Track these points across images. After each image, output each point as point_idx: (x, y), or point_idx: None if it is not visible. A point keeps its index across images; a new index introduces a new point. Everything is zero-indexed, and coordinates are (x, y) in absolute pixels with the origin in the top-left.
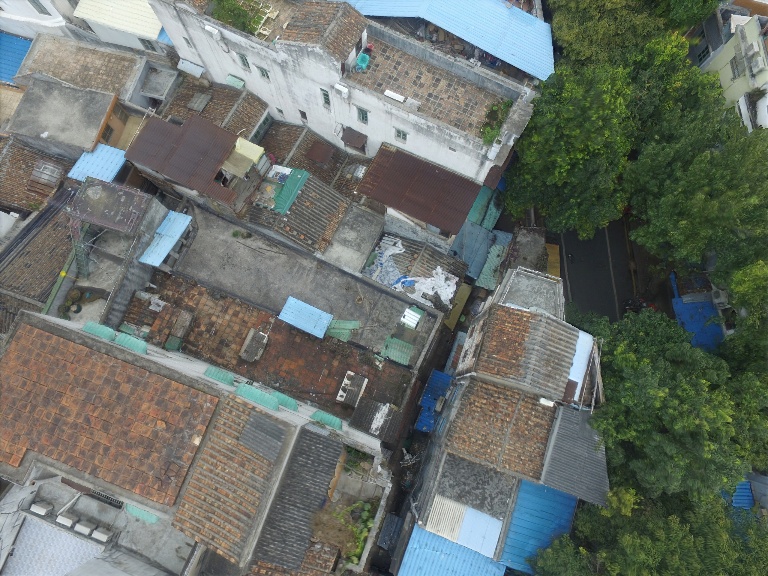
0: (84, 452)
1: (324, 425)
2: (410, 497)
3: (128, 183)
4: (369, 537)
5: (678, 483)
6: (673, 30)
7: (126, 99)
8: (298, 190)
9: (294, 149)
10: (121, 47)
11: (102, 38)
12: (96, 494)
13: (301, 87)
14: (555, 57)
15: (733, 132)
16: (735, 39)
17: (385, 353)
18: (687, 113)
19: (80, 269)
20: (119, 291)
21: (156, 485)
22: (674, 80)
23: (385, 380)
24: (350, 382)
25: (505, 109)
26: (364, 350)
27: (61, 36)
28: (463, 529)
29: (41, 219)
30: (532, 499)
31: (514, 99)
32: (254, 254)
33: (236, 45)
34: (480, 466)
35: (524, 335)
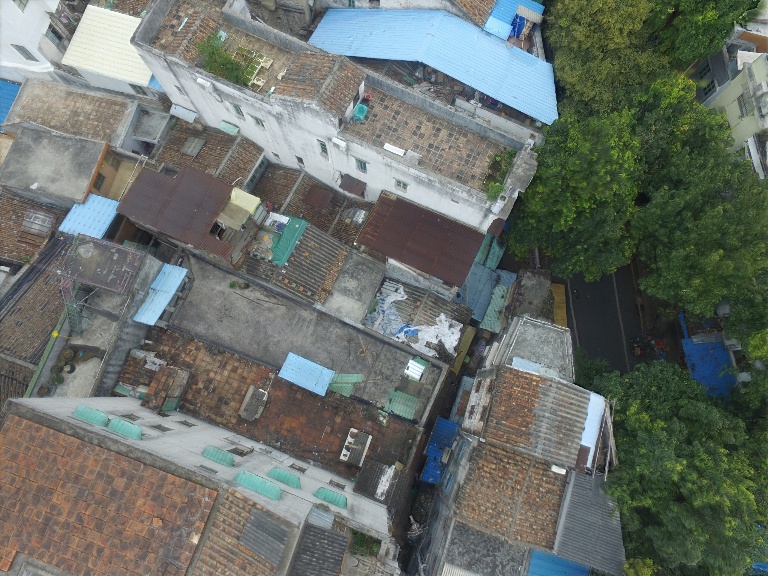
0: (77, 554)
1: (328, 507)
2: (417, 554)
3: (121, 233)
4: None
5: None
6: (677, 64)
7: (118, 145)
8: (296, 240)
9: (291, 194)
10: (111, 91)
11: (92, 83)
12: None
13: (297, 137)
14: (557, 96)
15: (746, 185)
16: (742, 77)
17: (389, 407)
18: (695, 156)
19: (73, 327)
20: (113, 353)
21: None
22: (681, 123)
23: (390, 436)
24: (354, 440)
25: (508, 159)
26: (367, 405)
27: (50, 81)
28: None
29: (32, 272)
30: (545, 565)
31: (517, 149)
32: (252, 306)
33: (229, 96)
34: None
35: (534, 401)
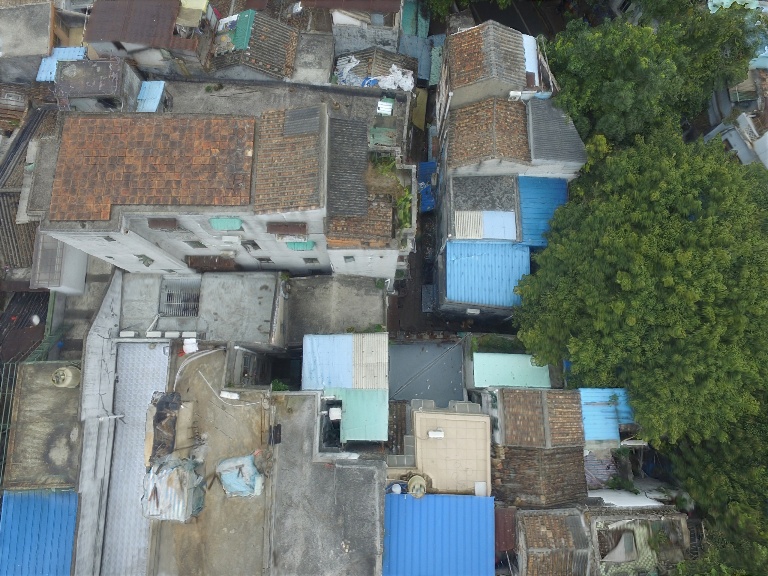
0: (160, 191)
1: None
2: (436, 259)
3: None
4: (412, 206)
5: (632, 101)
6: None
7: (62, 9)
8: (250, 27)
9: (232, 6)
10: None
11: None
12: (171, 315)
13: None
14: None
15: None
16: None
17: (374, 141)
18: None
19: None
20: None
21: (230, 194)
22: None
23: None
24: None
25: None
26: None
27: None
28: (485, 227)
29: (24, 134)
30: (531, 191)
31: None
32: (231, 100)
33: None
34: (482, 179)
35: (480, 45)
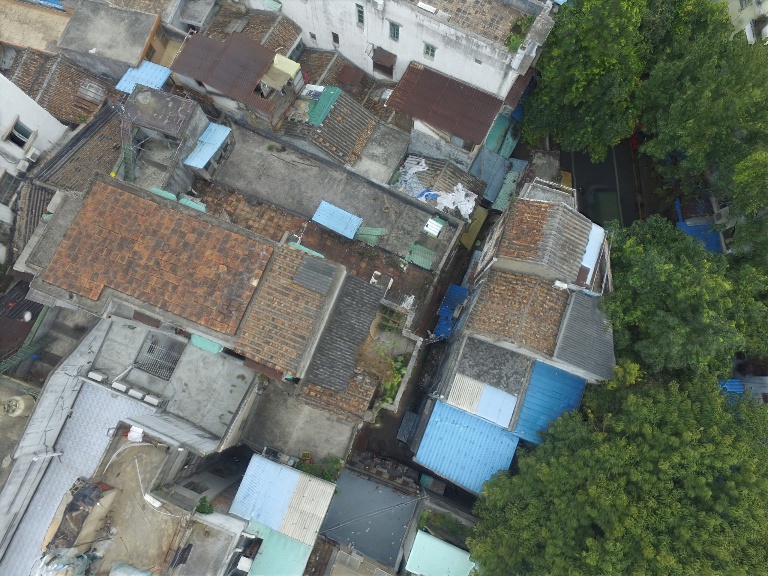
0: (155, 289)
1: None
2: (429, 393)
3: None
4: (402, 382)
5: (679, 348)
6: None
7: (168, 22)
8: (331, 105)
9: (326, 72)
10: None
11: None
12: (145, 369)
13: (337, 4)
14: None
15: (739, 41)
16: None
17: (409, 258)
18: (697, 37)
19: (127, 173)
20: (166, 188)
21: (219, 318)
22: (686, 4)
23: (409, 281)
24: (377, 281)
25: (528, 24)
26: (390, 254)
27: None
28: (481, 403)
29: (88, 131)
30: (544, 380)
31: (537, 15)
32: (288, 166)
33: None
34: (497, 349)
35: (542, 223)
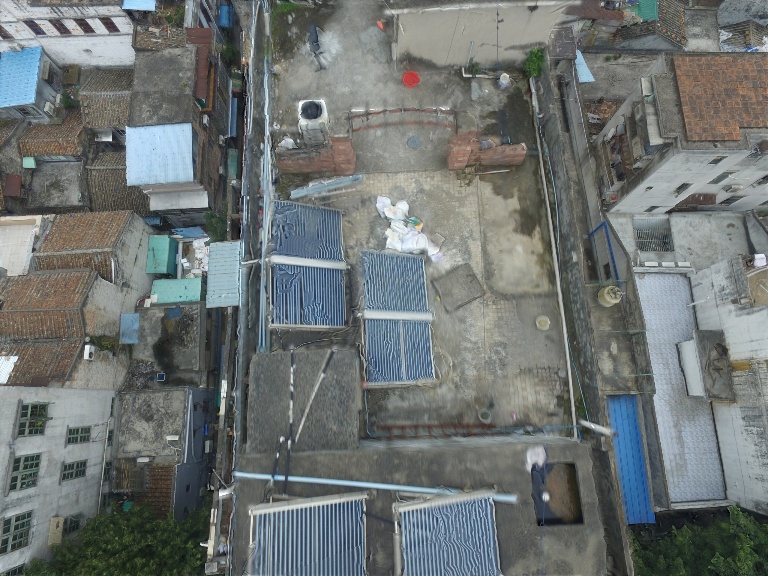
0: None
1: None
2: None
3: None
4: None
5: None
6: None
7: None
8: (656, 2)
9: None
10: None
11: None
12: None
13: None
14: None
15: None
16: None
17: None
18: None
19: None
20: None
21: None
22: None
23: None
24: None
25: None
26: None
27: None
28: None
29: None
30: None
31: None
32: (631, 68)
33: None
34: None
35: None
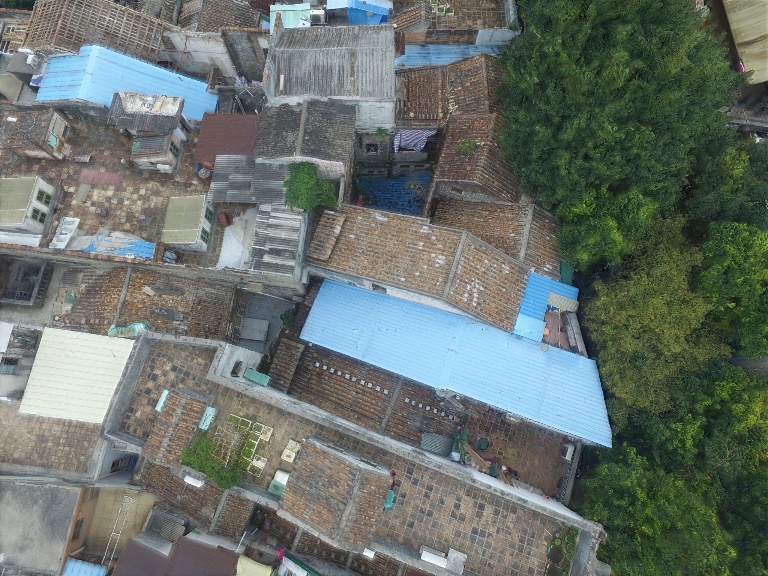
0: None
1: None
2: None
3: None
4: None
5: None
6: None
7: (95, 477)
8: None
9: None
10: None
11: None
12: None
13: None
14: None
15: None
16: None
17: None
18: None
19: None
20: None
21: None
22: (762, 448)
23: None
24: None
25: (570, 542)
26: None
27: None
28: None
29: None
30: None
31: None
32: None
33: None
34: None
35: None
